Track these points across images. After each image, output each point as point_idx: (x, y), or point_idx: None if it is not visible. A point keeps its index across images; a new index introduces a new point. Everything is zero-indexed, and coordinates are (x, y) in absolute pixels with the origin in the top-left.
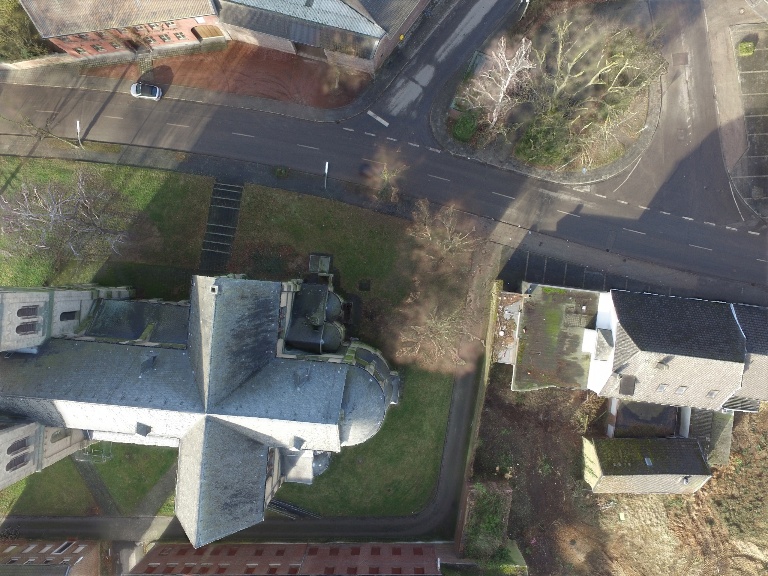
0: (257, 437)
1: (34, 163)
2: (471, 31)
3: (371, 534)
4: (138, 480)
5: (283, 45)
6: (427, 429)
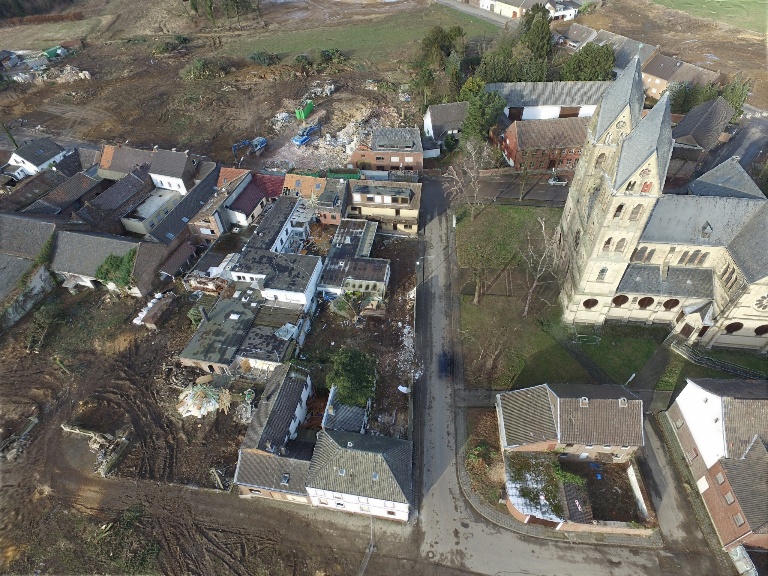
0: None
1: None
2: None
3: None
4: (628, 361)
5: None
6: None
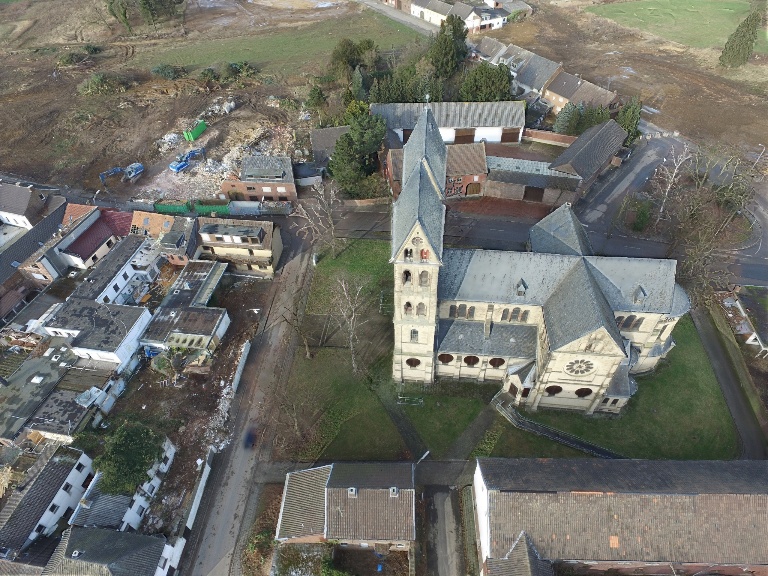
0: (607, 294)
1: (364, 240)
2: (621, 193)
3: None
4: (449, 425)
5: (517, 194)
6: (704, 388)
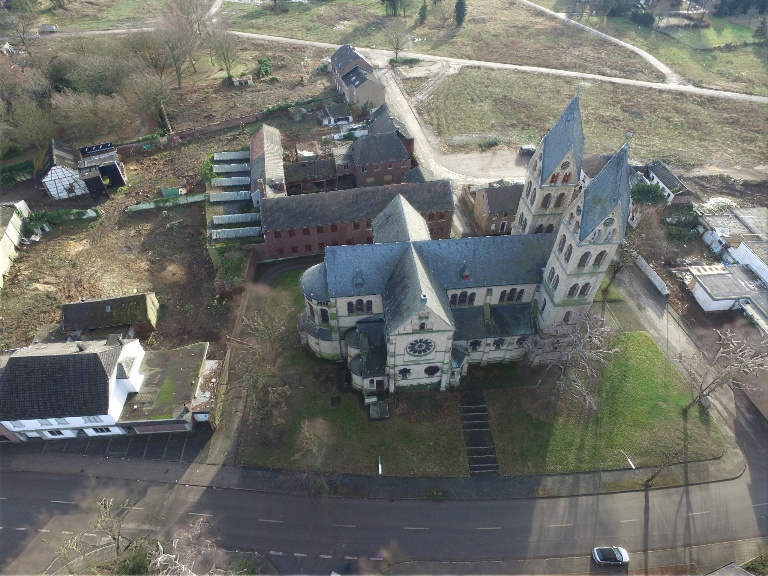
0: None
1: None
2: None
3: (314, 259)
4: None
5: None
6: None
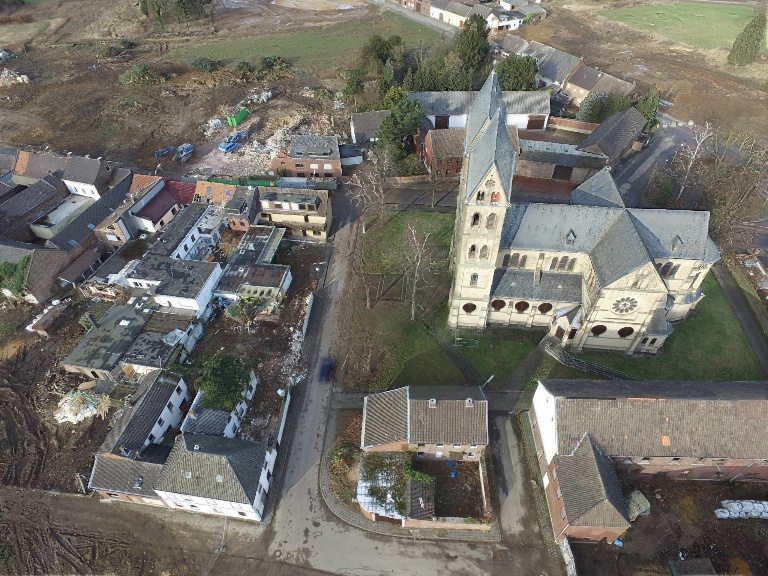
0: (648, 243)
1: (407, 212)
2: (643, 174)
3: None
4: (503, 363)
5: (547, 173)
6: (730, 334)
